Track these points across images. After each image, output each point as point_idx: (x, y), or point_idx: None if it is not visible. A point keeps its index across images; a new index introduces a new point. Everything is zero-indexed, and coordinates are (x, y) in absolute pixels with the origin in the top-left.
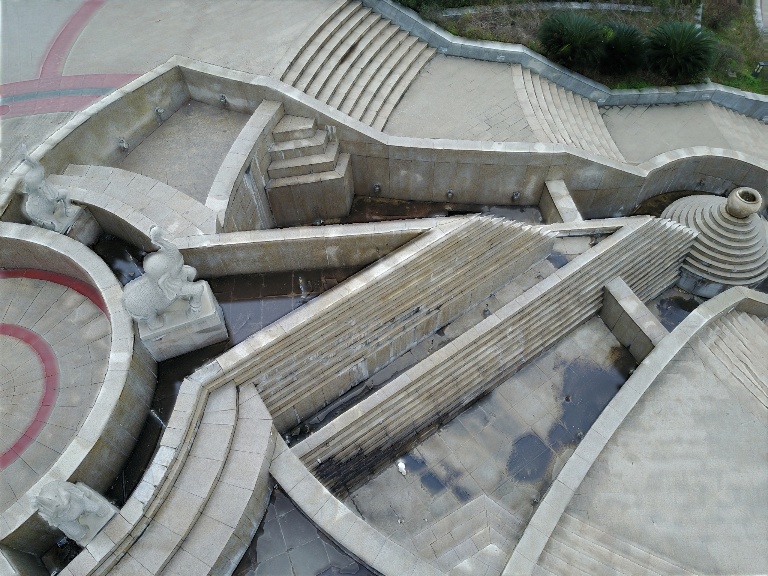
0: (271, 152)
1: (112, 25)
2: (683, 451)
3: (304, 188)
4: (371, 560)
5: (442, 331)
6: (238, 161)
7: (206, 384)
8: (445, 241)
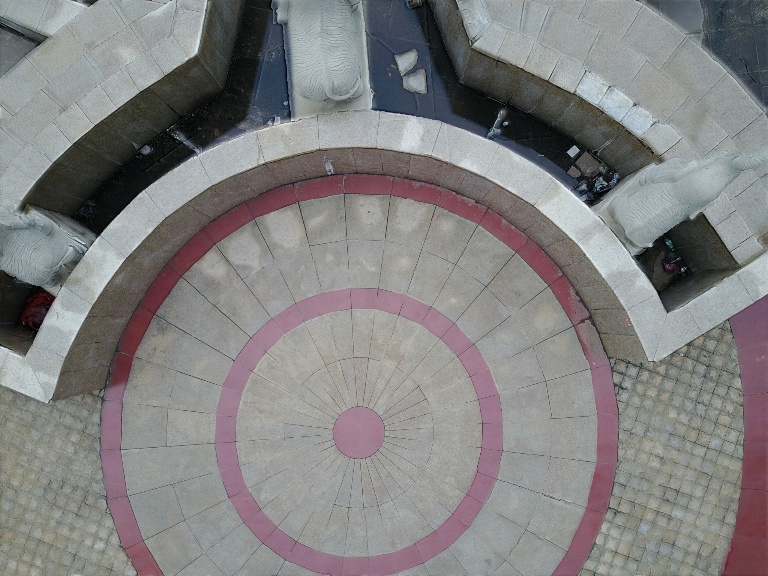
0: None
1: None
2: None
3: None
4: None
5: None
6: None
7: None
8: None
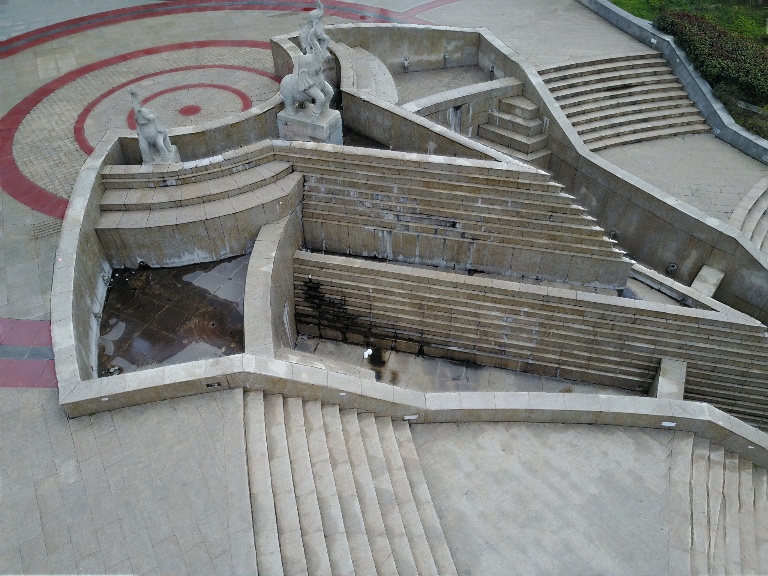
0: (490, 114)
1: (474, 6)
2: (559, 483)
3: None
4: (248, 298)
5: (473, 273)
6: (453, 95)
7: (276, 150)
8: (505, 177)
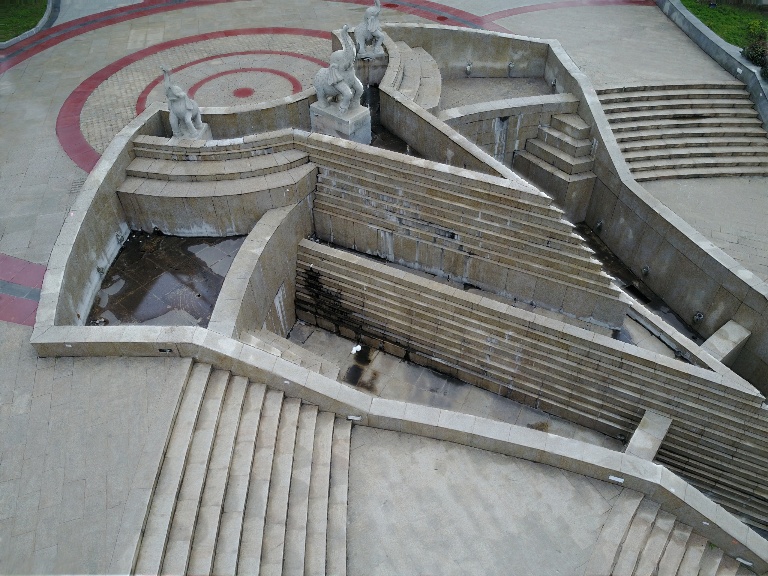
0: (540, 129)
1: (558, 16)
2: (480, 513)
3: (539, 172)
4: (230, 276)
5: (469, 287)
6: (501, 106)
7: (296, 140)
8: (507, 195)
